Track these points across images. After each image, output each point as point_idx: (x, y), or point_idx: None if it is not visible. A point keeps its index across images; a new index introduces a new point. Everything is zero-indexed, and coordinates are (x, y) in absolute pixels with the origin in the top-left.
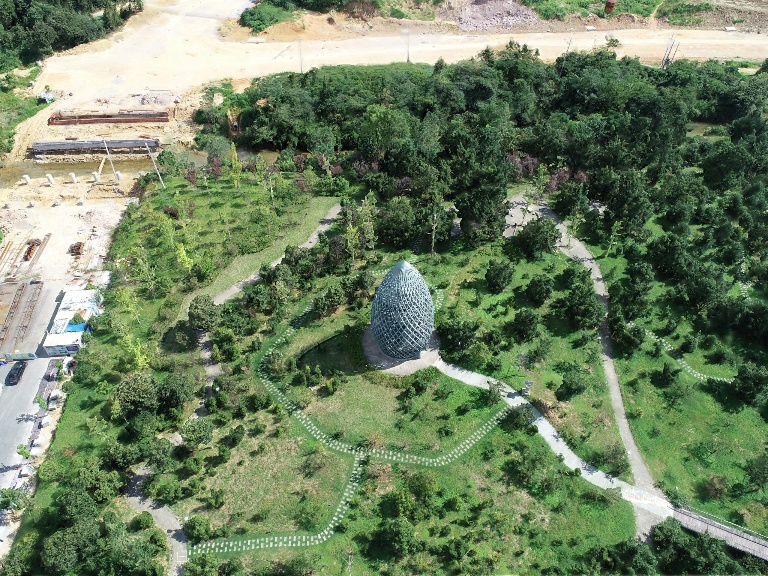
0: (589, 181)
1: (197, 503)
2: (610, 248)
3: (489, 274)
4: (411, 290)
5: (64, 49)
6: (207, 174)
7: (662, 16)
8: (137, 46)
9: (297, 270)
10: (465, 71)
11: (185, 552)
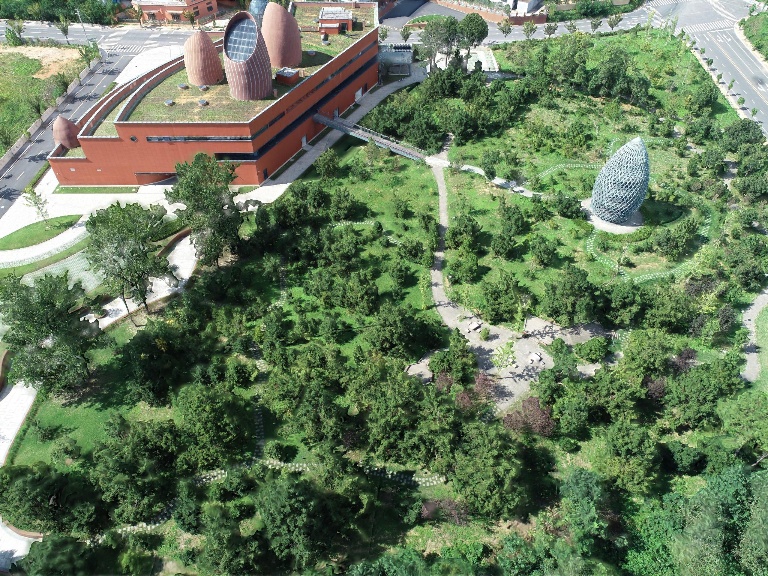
0: None
1: None
2: None
3: None
4: None
5: None
6: None
7: None
8: None
9: None
10: None
11: None
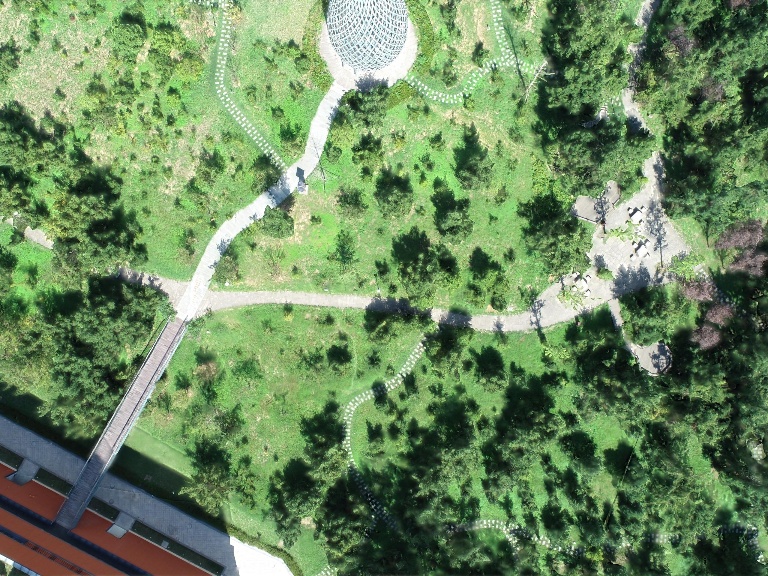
0: None
1: None
2: None
3: None
4: None
5: None
6: None
7: None
8: None
9: None
10: None
11: None
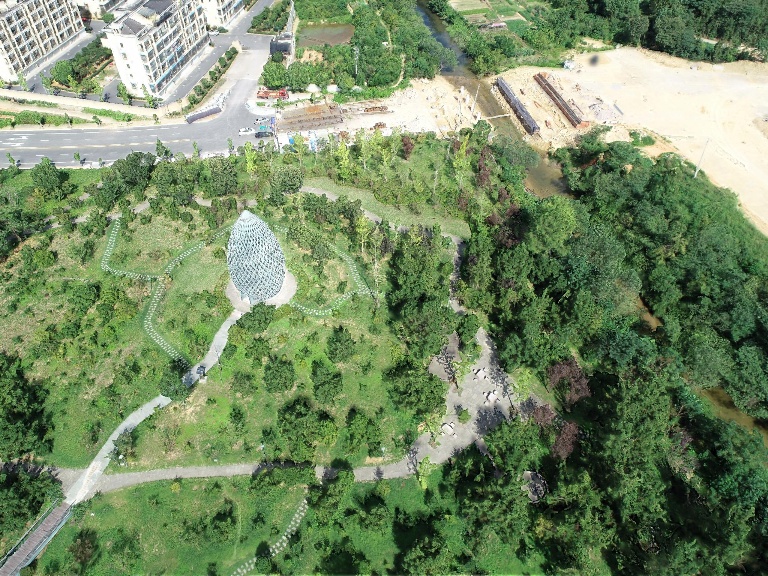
0: None
1: None
2: None
3: None
4: (234, 231)
5: (651, 48)
6: None
7: None
8: (691, 78)
9: None
10: None
11: None
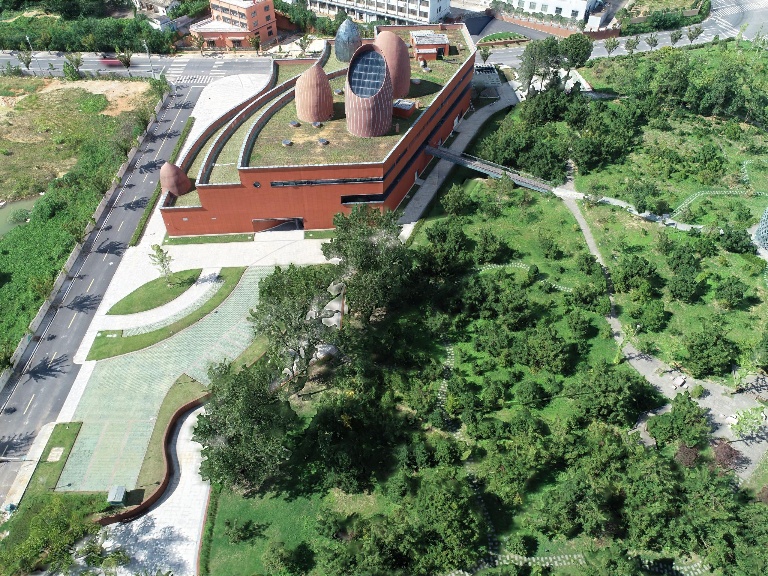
0: None
1: None
2: None
3: None
4: None
5: None
6: None
7: None
8: None
9: None
10: None
11: None
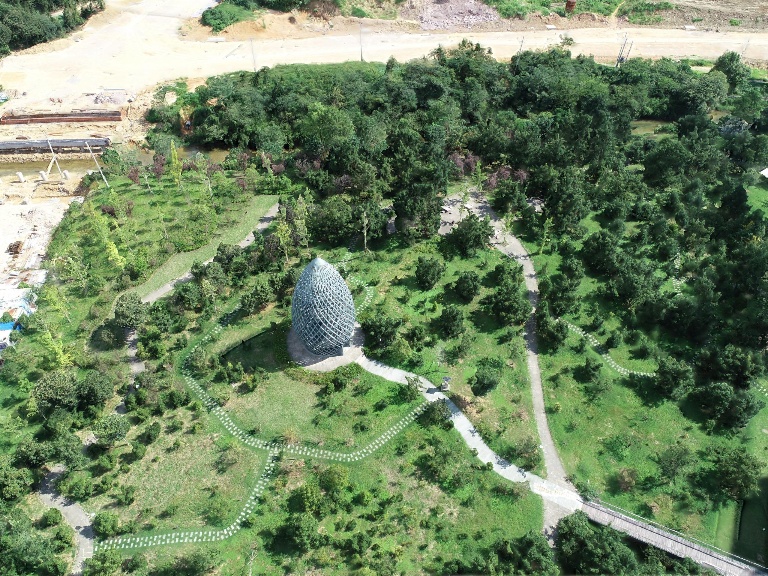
0: (532, 179)
1: (108, 500)
2: (545, 245)
3: (418, 271)
4: (325, 286)
5: (22, 48)
6: (153, 173)
7: (622, 15)
8: (96, 45)
9: (231, 268)
10: (416, 70)
11: (91, 548)
